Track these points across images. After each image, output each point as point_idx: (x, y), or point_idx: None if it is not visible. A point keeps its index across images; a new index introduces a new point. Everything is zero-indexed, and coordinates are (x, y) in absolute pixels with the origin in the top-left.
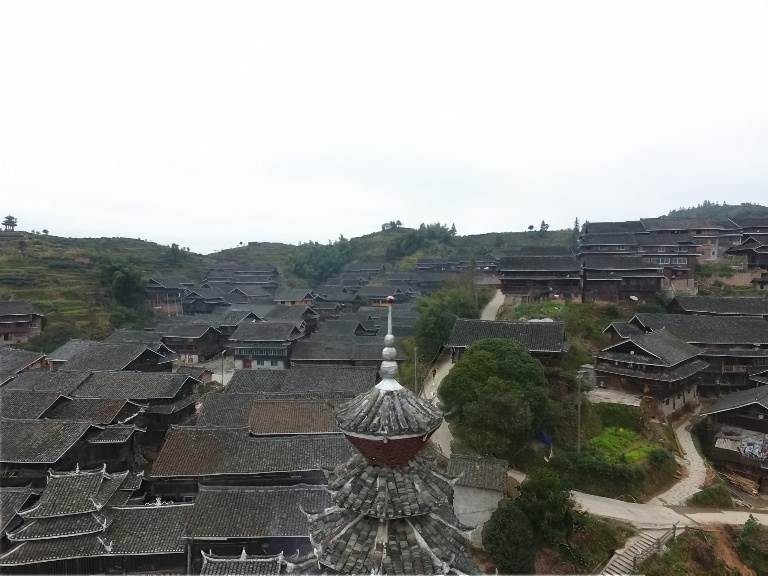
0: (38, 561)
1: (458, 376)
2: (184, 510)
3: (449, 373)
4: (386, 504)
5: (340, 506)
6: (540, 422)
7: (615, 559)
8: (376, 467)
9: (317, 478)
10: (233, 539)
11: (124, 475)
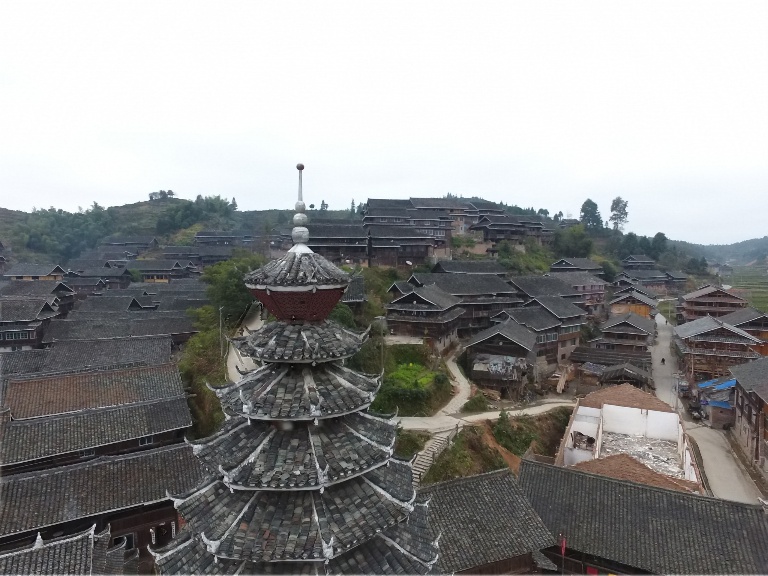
0: None
1: None
2: None
3: None
4: None
5: (266, 362)
6: (352, 361)
7: (419, 459)
8: (296, 325)
9: (116, 452)
10: (10, 536)
11: None
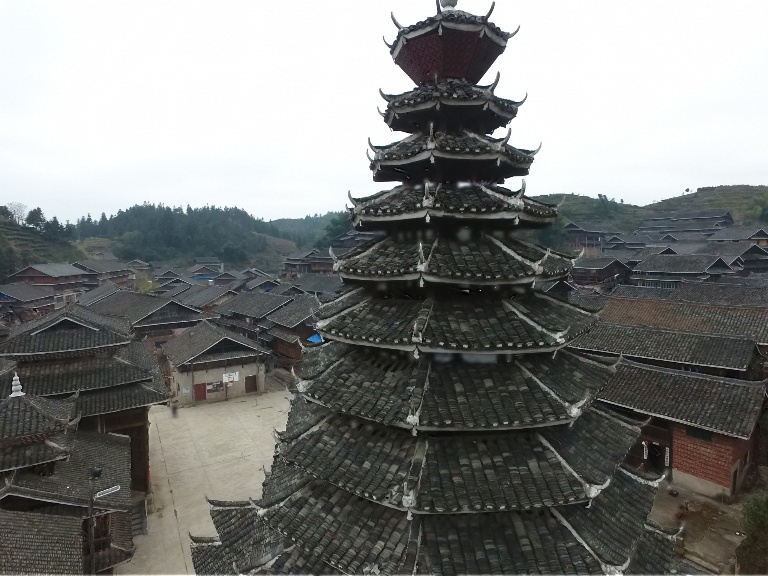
0: None
1: None
2: None
3: None
4: (399, 99)
5: (390, 127)
6: None
7: None
8: None
9: None
10: None
11: None
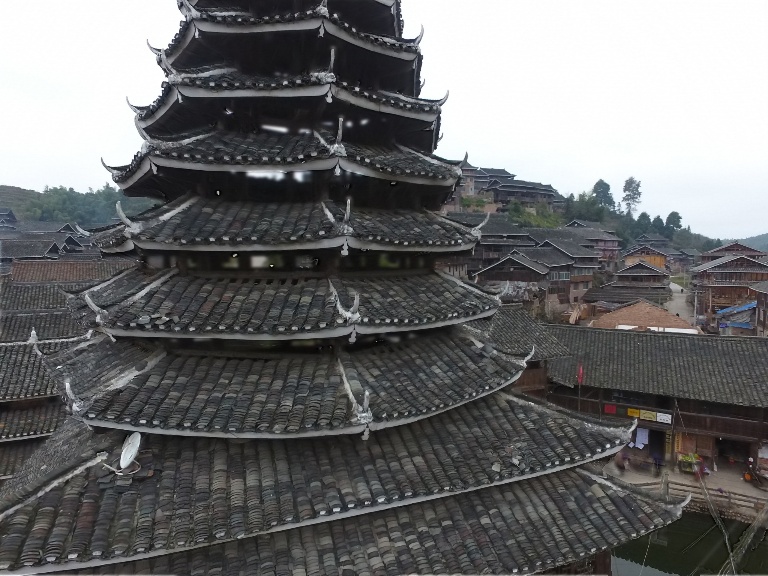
0: None
1: None
2: None
3: None
4: None
5: None
6: None
7: None
8: None
9: None
10: None
11: None
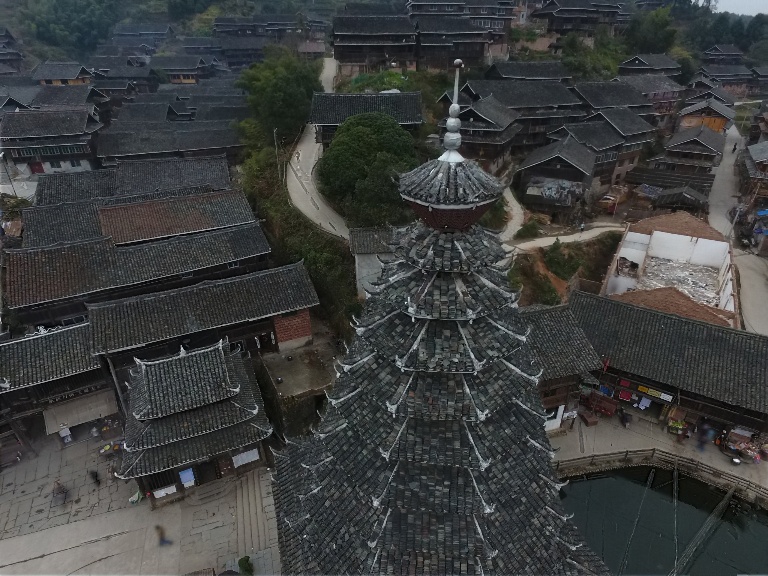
0: None
1: (340, 155)
2: (79, 331)
3: (327, 153)
4: None
5: None
6: None
7: None
8: (448, 234)
9: (211, 274)
10: (152, 343)
11: None
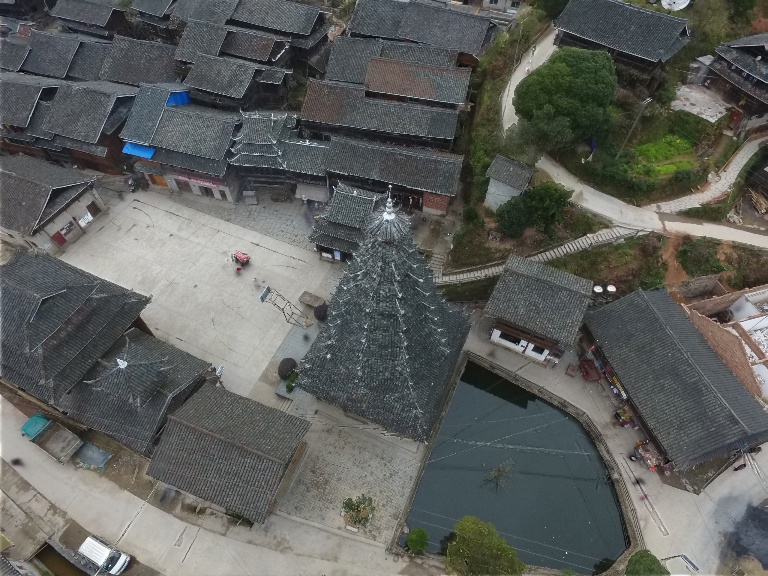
0: (250, 165)
1: (532, 85)
2: (323, 150)
3: (529, 76)
4: (380, 258)
5: None
6: (589, 135)
7: (583, 239)
8: None
9: (410, 139)
10: (352, 175)
11: (284, 117)
